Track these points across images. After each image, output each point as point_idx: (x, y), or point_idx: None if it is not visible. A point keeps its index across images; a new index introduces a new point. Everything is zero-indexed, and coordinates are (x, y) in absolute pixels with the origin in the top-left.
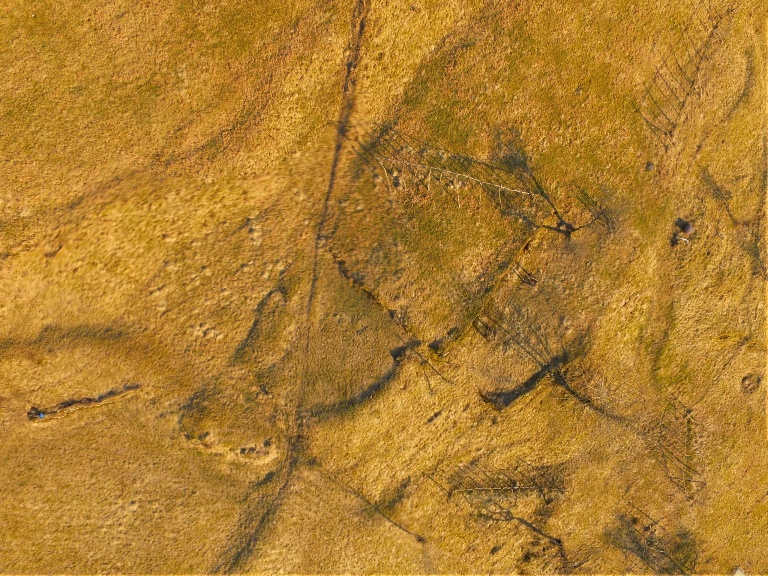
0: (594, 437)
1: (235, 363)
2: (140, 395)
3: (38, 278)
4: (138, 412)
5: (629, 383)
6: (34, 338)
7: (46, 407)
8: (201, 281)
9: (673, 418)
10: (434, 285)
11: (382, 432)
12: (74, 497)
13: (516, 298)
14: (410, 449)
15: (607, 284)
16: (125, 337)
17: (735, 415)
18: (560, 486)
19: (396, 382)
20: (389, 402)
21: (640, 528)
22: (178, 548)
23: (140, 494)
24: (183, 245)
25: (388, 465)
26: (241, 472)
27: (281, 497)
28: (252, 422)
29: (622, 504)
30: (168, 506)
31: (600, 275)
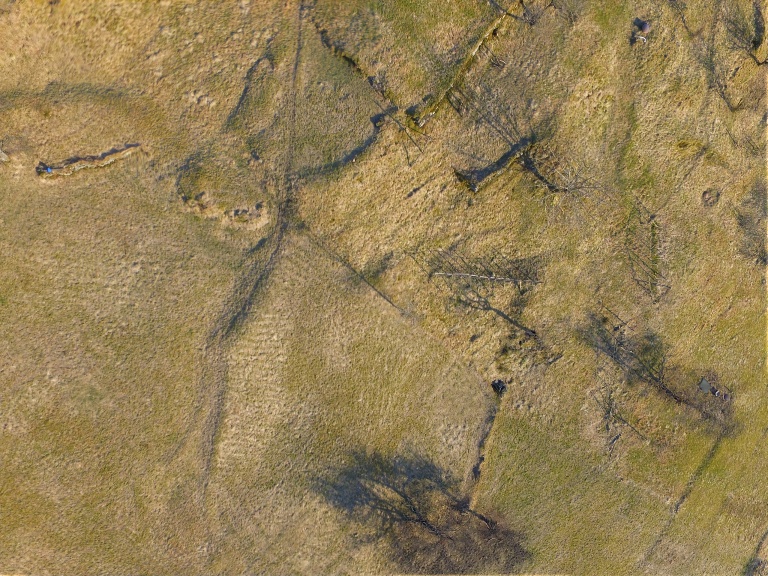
0: (564, 233)
1: (227, 130)
2: (140, 154)
3: (44, 28)
4: (138, 174)
5: (595, 179)
6: (41, 90)
7: (53, 162)
8: (194, 48)
9: (638, 222)
10: (409, 53)
11: (365, 203)
12: (81, 255)
13: (486, 77)
14: (392, 224)
15: (571, 73)
16: (125, 97)
17: (696, 224)
18: (533, 277)
19: (377, 152)
20: (371, 174)
21: (610, 328)
22: (178, 310)
23: (142, 256)
24: (177, 10)
25: (372, 237)
26: (235, 239)
27: (273, 262)
28: (244, 186)
29: (592, 303)
30: (168, 268)
31: (564, 64)
